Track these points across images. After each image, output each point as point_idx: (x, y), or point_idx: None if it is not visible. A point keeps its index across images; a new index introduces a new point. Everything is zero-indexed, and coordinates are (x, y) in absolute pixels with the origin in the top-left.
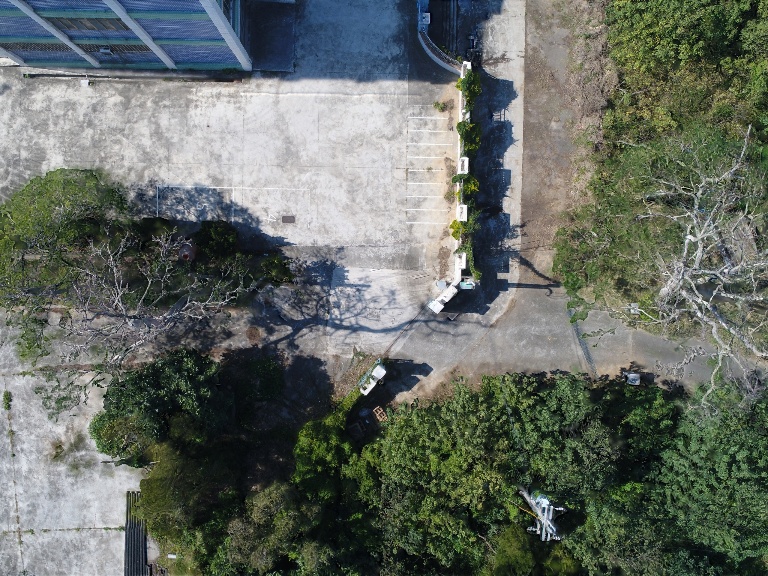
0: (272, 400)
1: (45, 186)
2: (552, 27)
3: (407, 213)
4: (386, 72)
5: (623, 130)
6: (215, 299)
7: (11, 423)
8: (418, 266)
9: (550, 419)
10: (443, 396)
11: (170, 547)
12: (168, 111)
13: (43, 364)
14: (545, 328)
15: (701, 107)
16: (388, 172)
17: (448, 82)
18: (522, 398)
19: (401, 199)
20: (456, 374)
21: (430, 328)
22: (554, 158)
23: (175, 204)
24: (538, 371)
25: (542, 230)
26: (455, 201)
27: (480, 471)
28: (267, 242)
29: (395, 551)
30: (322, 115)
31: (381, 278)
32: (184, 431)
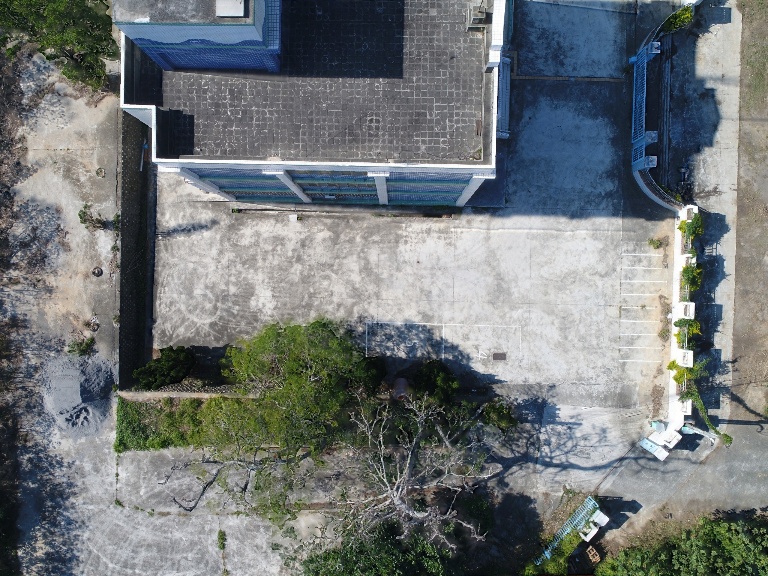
0: None
1: (289, 346)
2: (766, 160)
3: (620, 351)
4: (599, 208)
5: None
6: (477, 473)
7: (225, 562)
8: (631, 404)
9: None
10: (652, 534)
11: None
12: (377, 247)
13: (257, 503)
14: (755, 464)
15: None
16: (601, 309)
17: (663, 219)
18: (758, 554)
19: (614, 337)
20: (665, 511)
21: (640, 465)
22: (767, 293)
23: (385, 340)
24: (748, 508)
25: (754, 366)
26: (669, 339)
27: None
28: (478, 379)
29: None
30: (534, 251)
31: (593, 416)
32: None
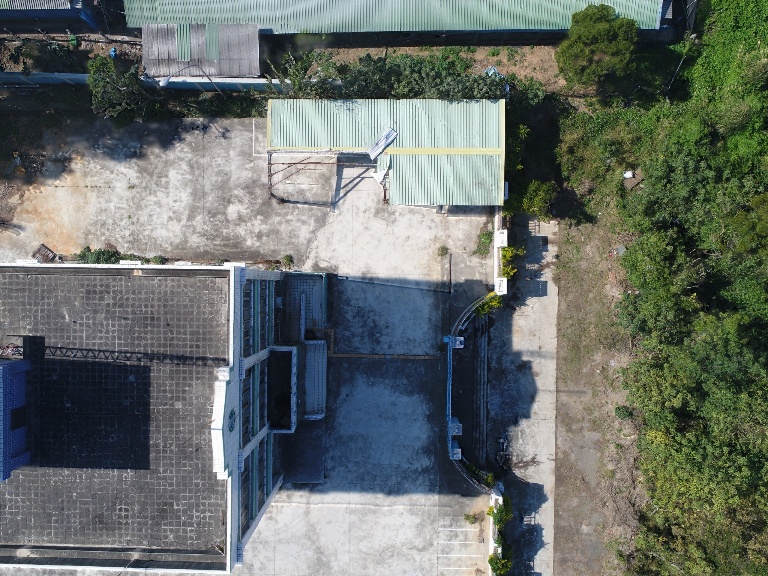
0: None
1: None
2: (583, 431)
3: None
4: (416, 484)
5: None
6: None
7: None
8: None
9: None
10: None
11: None
12: None
13: None
14: None
15: (736, 550)
16: None
17: (478, 494)
18: None
19: None
20: None
21: None
22: (585, 561)
23: None
24: None
25: None
26: None
27: None
28: None
29: None
30: (353, 526)
31: None
32: None
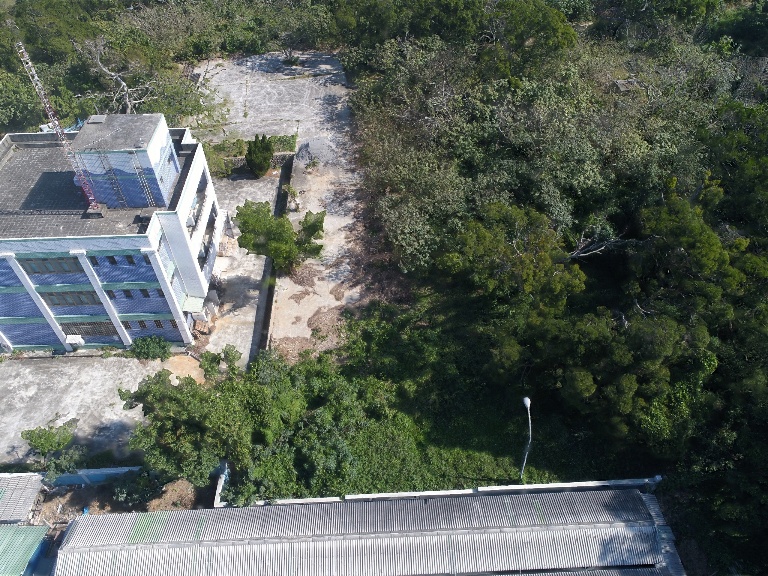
0: None
1: None
2: None
3: None
4: None
5: None
6: None
7: (245, 109)
8: None
9: None
10: None
11: None
12: None
13: None
14: None
15: None
16: None
17: None
18: None
19: None
20: None
21: None
22: None
23: None
24: None
25: None
26: None
27: None
28: None
29: None
30: None
31: None
32: None
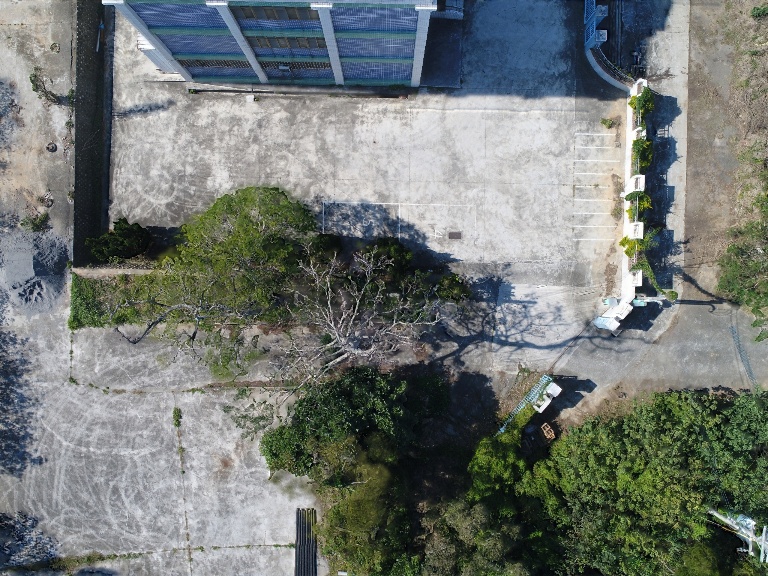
0: (438, 417)
1: (240, 205)
2: (716, 43)
3: (574, 229)
4: (553, 88)
5: None
6: (424, 319)
7: (181, 440)
8: (584, 283)
9: (744, 438)
10: (607, 412)
11: (340, 564)
12: (334, 127)
13: (212, 381)
14: (708, 344)
15: None
16: (555, 188)
17: (615, 99)
18: (706, 416)
19: (568, 215)
20: (619, 390)
21: (594, 344)
22: (718, 174)
23: (341, 220)
24: (700, 387)
25: (705, 246)
26: (622, 218)
27: (678, 491)
28: (433, 258)
29: (582, 570)
30: (489, 131)
31: (547, 294)
32: (382, 451)
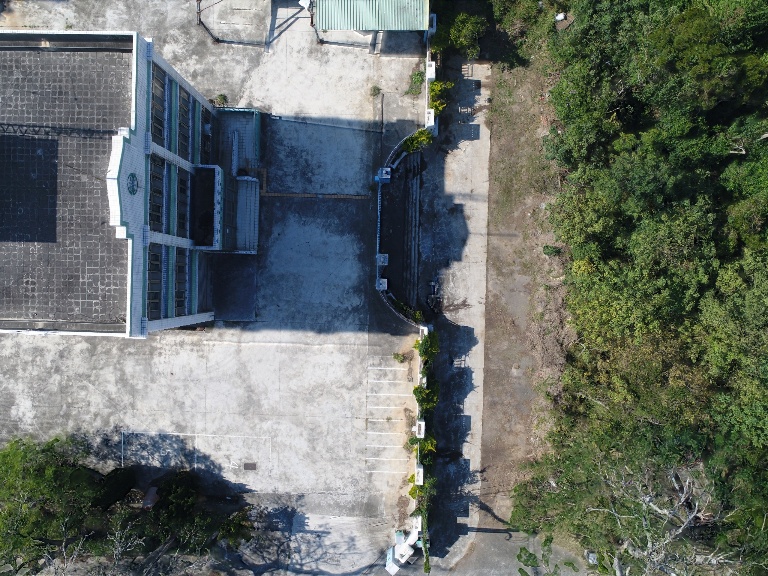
0: None
1: (6, 473)
2: (513, 274)
3: (367, 462)
4: (346, 323)
5: (582, 386)
6: None
7: None
8: (377, 514)
9: None
10: None
11: None
12: (133, 358)
13: None
14: (504, 571)
15: (657, 379)
16: (348, 421)
17: (408, 333)
18: None
19: (361, 448)
20: None
21: None
22: (514, 405)
23: (140, 450)
24: None
25: (502, 475)
26: (414, 451)
27: None
28: (229, 488)
29: None
30: (283, 364)
31: (341, 525)
32: None
